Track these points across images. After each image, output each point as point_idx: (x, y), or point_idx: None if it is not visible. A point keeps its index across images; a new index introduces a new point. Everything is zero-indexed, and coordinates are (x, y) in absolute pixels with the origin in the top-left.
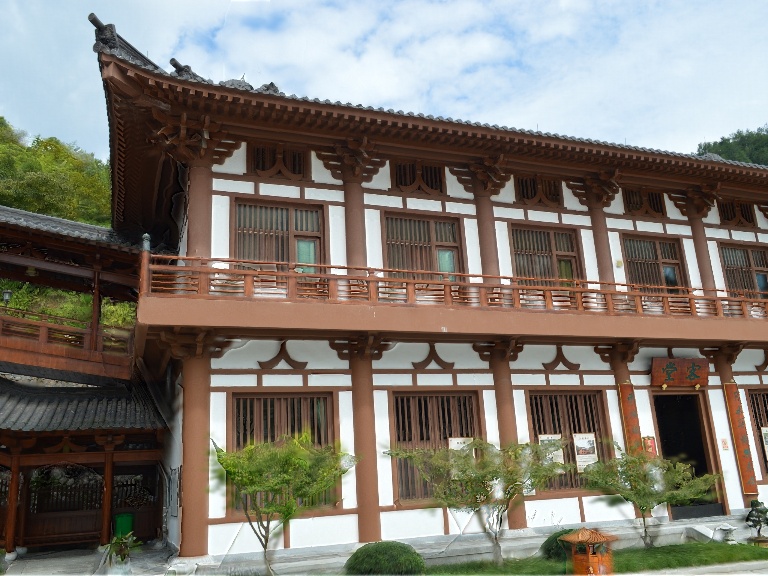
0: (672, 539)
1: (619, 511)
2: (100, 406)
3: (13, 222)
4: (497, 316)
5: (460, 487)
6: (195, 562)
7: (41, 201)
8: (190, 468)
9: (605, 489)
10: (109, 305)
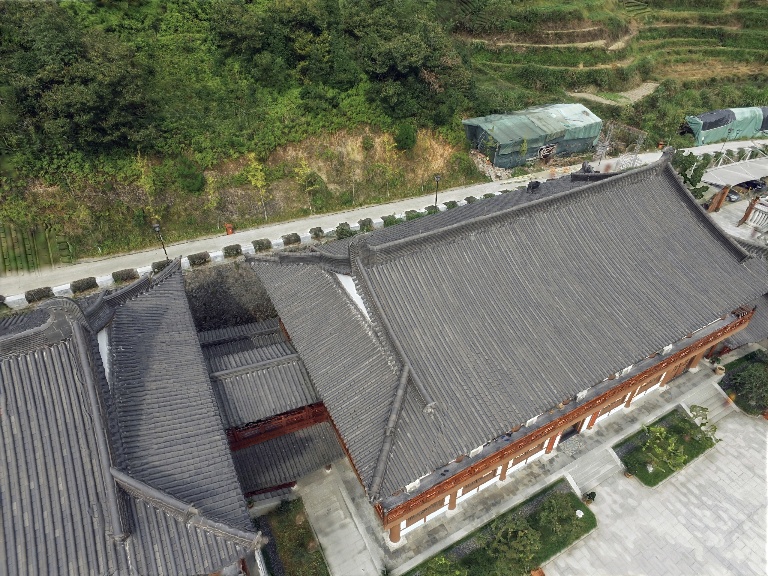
0: (557, 479)
1: (539, 454)
2: (313, 427)
3: (268, 416)
4: (520, 451)
5: (506, 575)
6: (398, 545)
7: (121, 96)
8: (395, 527)
9: (537, 450)
10: (197, 153)
